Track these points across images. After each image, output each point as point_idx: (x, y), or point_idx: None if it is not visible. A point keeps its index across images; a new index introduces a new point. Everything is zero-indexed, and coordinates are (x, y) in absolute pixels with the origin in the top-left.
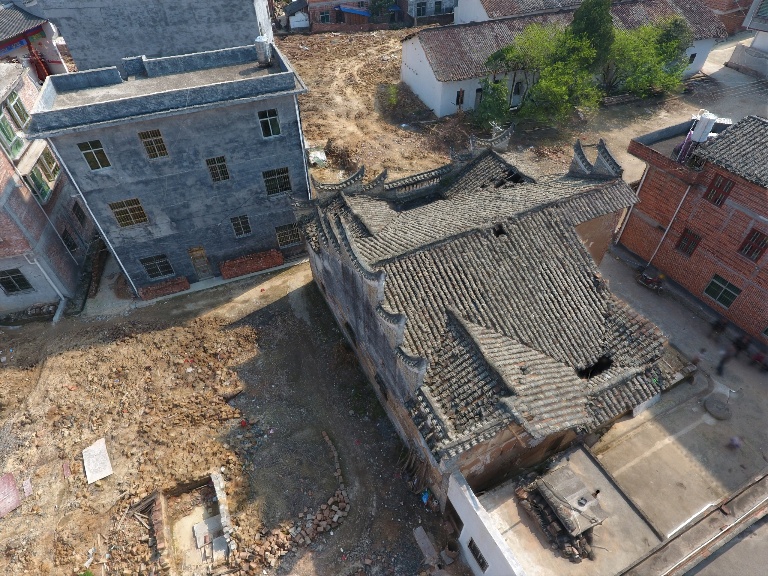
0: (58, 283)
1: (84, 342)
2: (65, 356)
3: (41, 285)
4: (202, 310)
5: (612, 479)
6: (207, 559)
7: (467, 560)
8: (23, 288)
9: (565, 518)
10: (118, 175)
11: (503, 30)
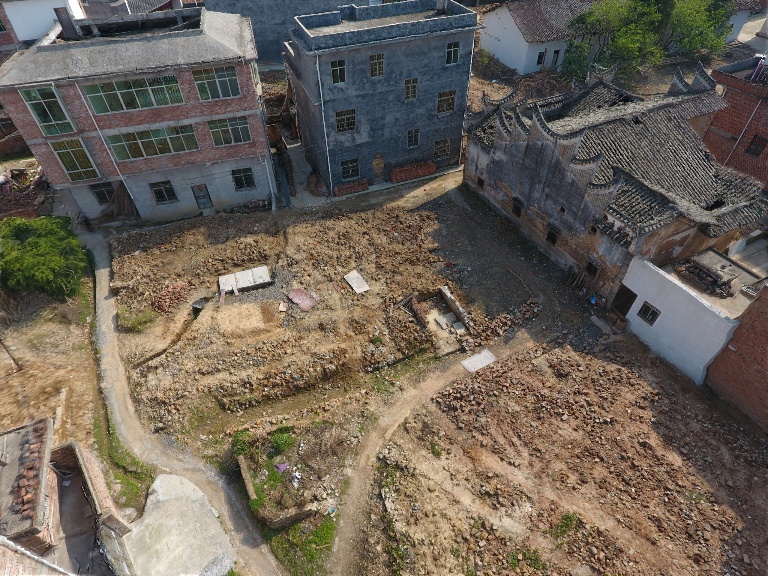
0: (273, 182)
1: (309, 219)
2: (301, 226)
3: (261, 183)
4: (384, 202)
5: (736, 263)
6: (453, 334)
7: (632, 330)
8: (248, 186)
9: (716, 273)
10: (348, 89)
11: (575, 2)
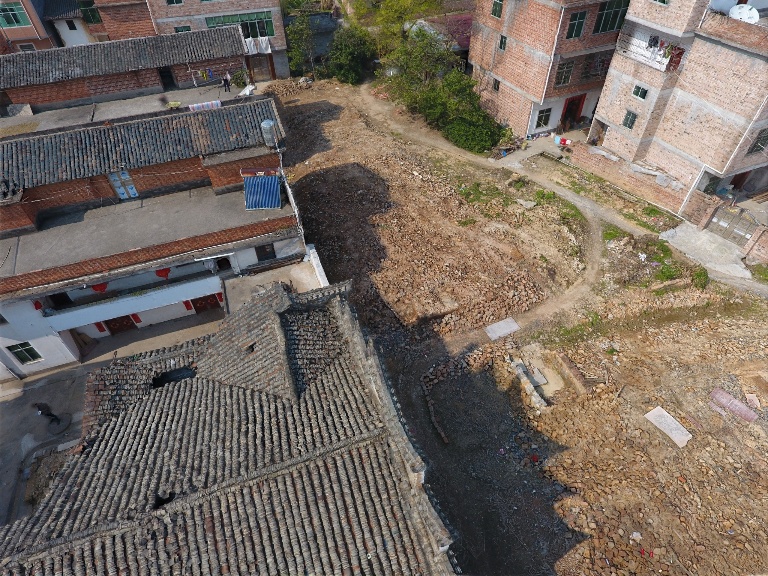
0: None
1: None
2: None
3: None
4: None
5: None
6: None
7: None
8: None
9: None
10: None
11: None
